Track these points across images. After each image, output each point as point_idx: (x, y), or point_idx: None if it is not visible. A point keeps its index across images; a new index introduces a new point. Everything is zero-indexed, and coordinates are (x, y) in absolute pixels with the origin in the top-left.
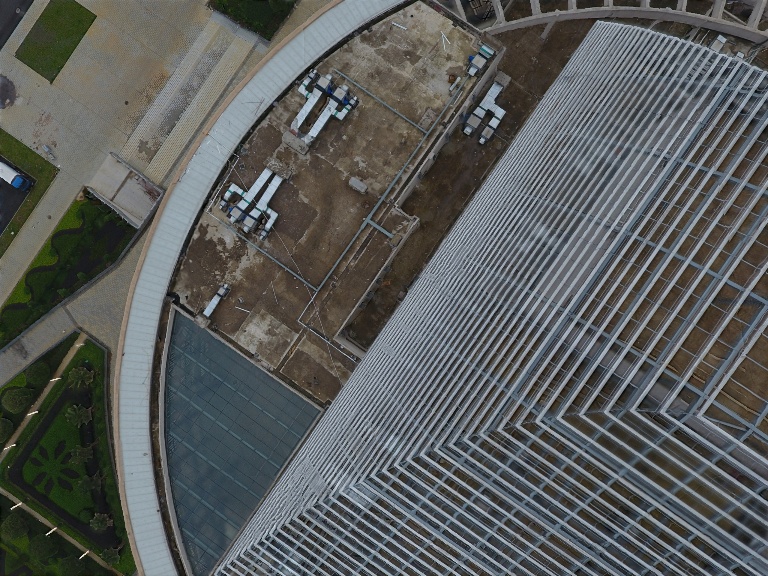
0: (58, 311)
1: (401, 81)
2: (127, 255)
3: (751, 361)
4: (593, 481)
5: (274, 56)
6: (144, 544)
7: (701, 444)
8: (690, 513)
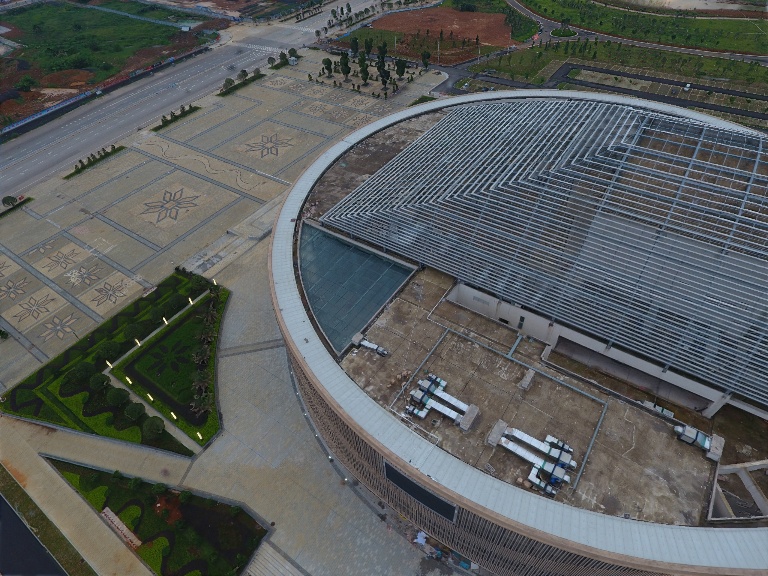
0: None
1: None
2: None
3: None
4: None
5: (700, 113)
6: None
7: None
8: None
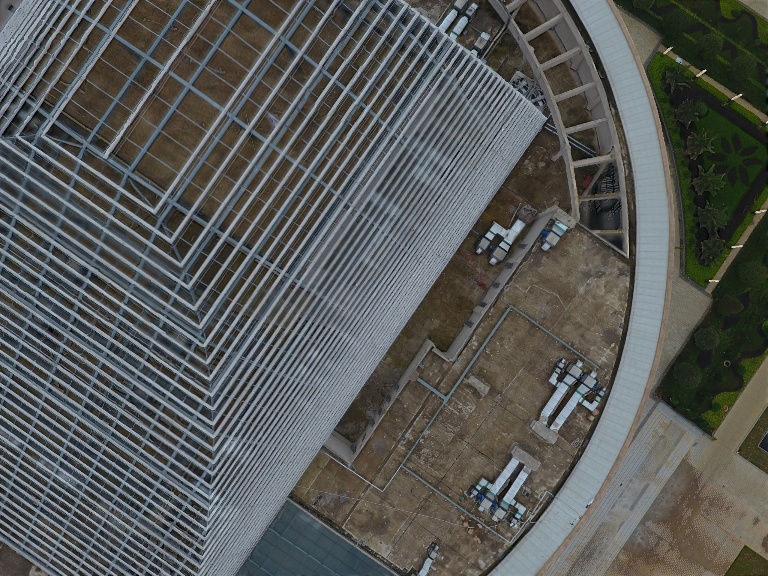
0: None
1: None
2: None
3: (91, 84)
4: (0, 223)
5: None
6: None
7: (55, 167)
8: (76, 245)
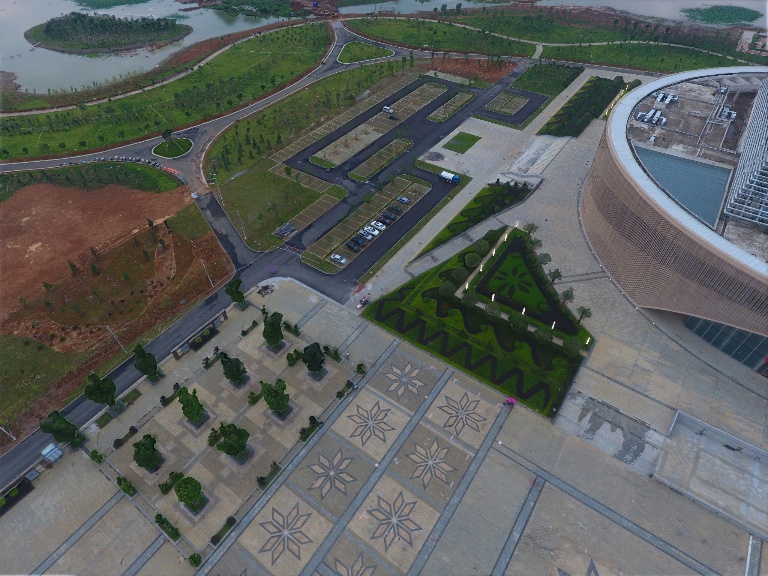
0: (491, 219)
1: (692, 95)
2: (528, 199)
3: None
4: None
5: (636, 89)
6: (668, 209)
7: None
8: None
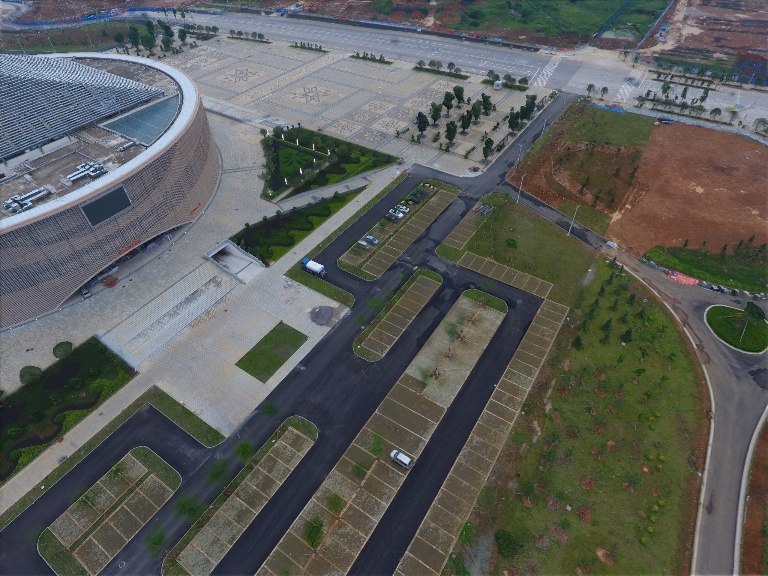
0: None
1: None
2: None
3: None
4: None
5: None
6: None
7: None
8: None
